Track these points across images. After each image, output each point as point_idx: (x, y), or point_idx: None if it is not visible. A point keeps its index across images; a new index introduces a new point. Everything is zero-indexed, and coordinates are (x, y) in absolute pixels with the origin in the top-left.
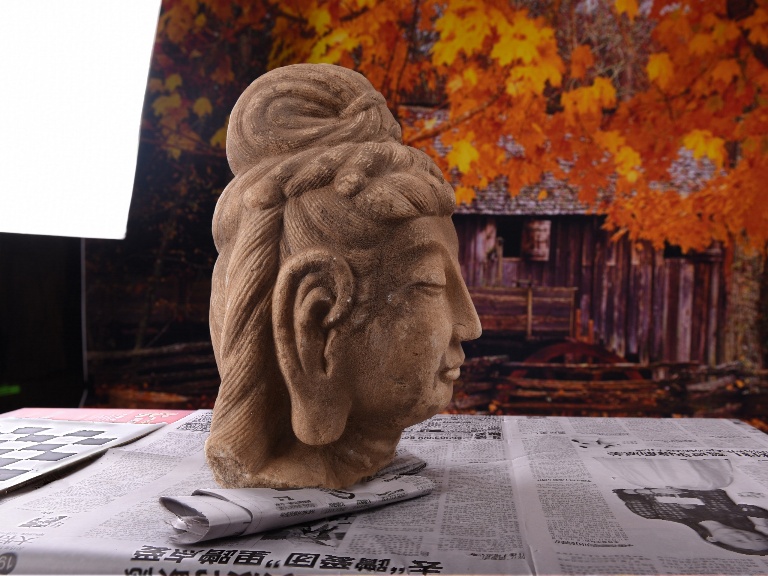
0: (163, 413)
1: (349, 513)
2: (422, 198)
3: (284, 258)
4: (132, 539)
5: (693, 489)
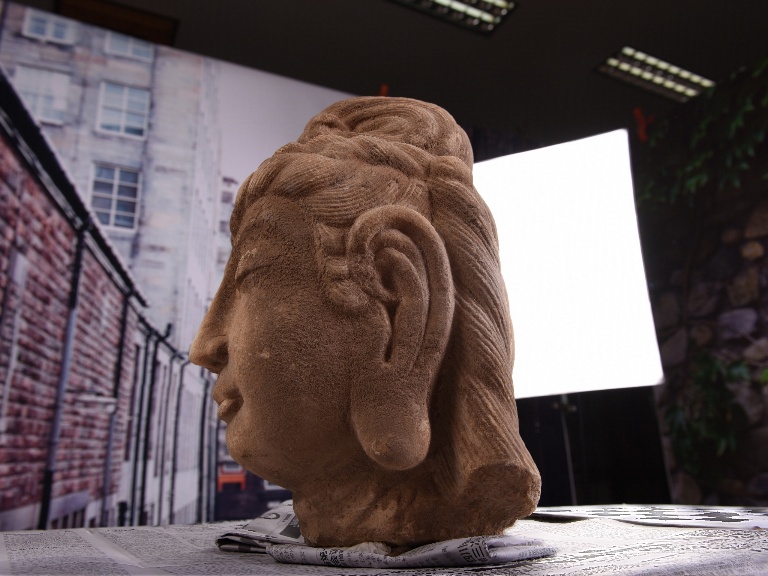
0: None
1: None
2: None
3: None
4: None
5: None
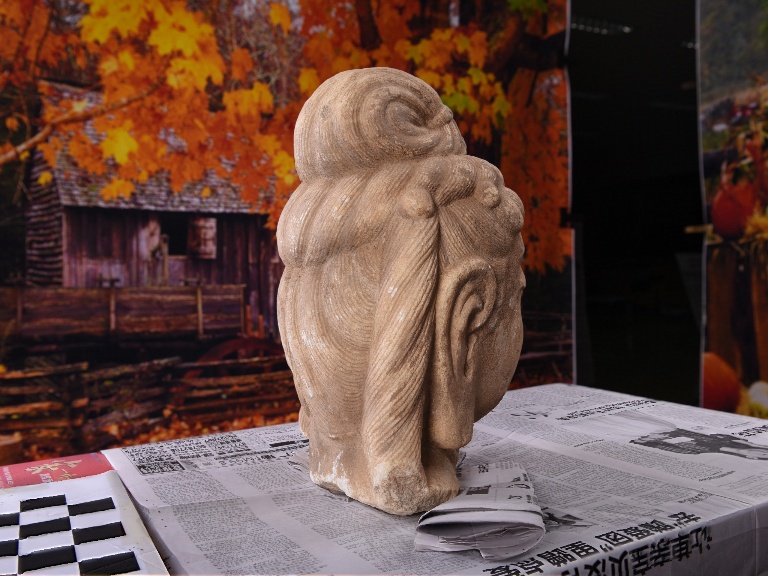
0: (59, 463)
1: None
2: None
3: (444, 267)
4: (455, 570)
5: None
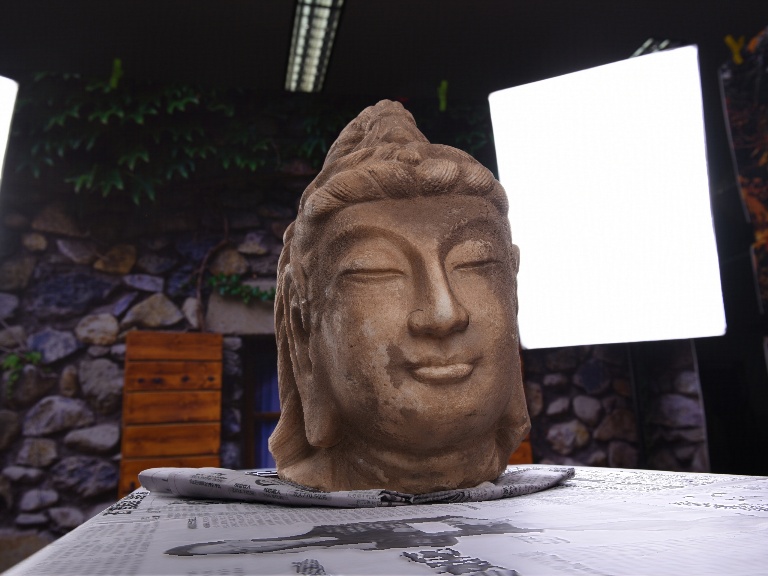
0: None
1: (269, 502)
2: (343, 188)
3: None
4: None
5: (520, 526)
